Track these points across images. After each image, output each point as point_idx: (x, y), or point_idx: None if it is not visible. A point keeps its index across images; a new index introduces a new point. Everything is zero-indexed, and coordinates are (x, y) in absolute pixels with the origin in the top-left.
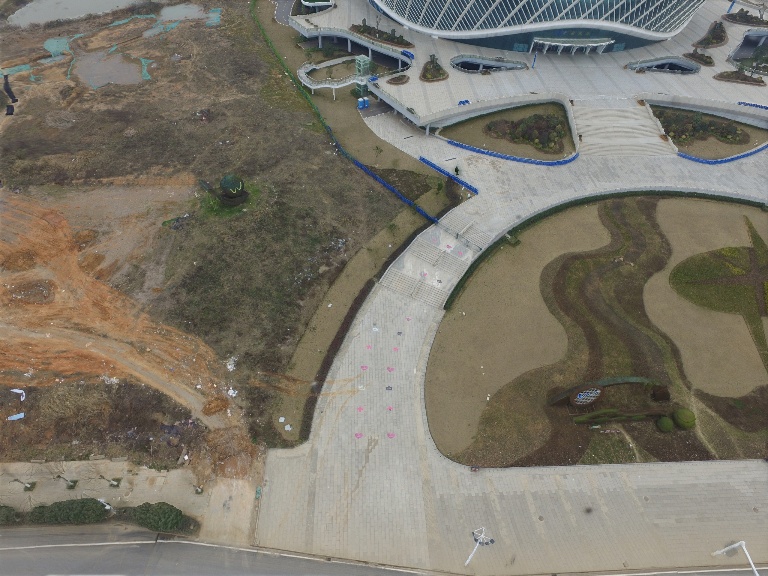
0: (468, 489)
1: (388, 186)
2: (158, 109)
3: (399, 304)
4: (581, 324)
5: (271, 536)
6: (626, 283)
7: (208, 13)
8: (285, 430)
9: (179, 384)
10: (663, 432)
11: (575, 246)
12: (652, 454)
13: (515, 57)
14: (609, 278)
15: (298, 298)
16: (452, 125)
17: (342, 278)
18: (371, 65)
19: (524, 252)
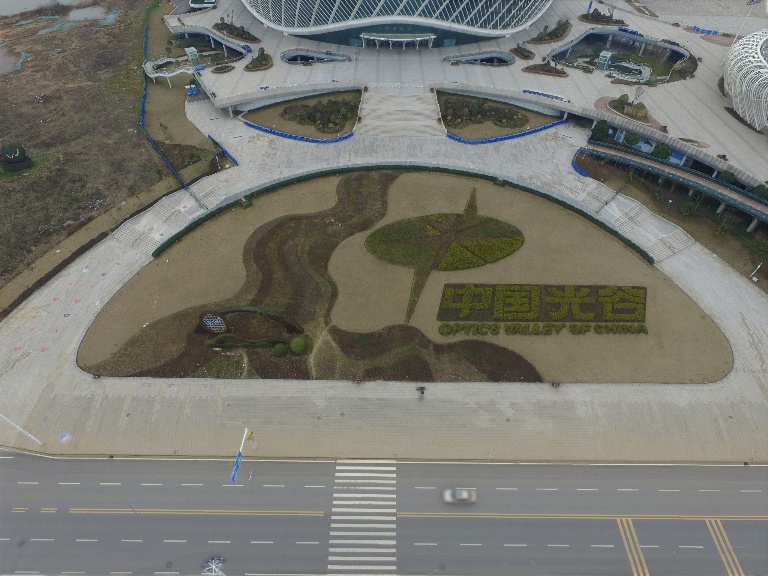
0: (81, 391)
1: (163, 158)
2: (8, 94)
3: (118, 252)
4: (263, 271)
5: None
6: (325, 240)
7: (108, 14)
8: None
9: None
10: (278, 356)
11: (299, 209)
12: (257, 373)
13: (347, 51)
14: (312, 236)
15: (33, 244)
16: (256, 109)
17: (81, 230)
18: (212, 58)
19: (250, 213)
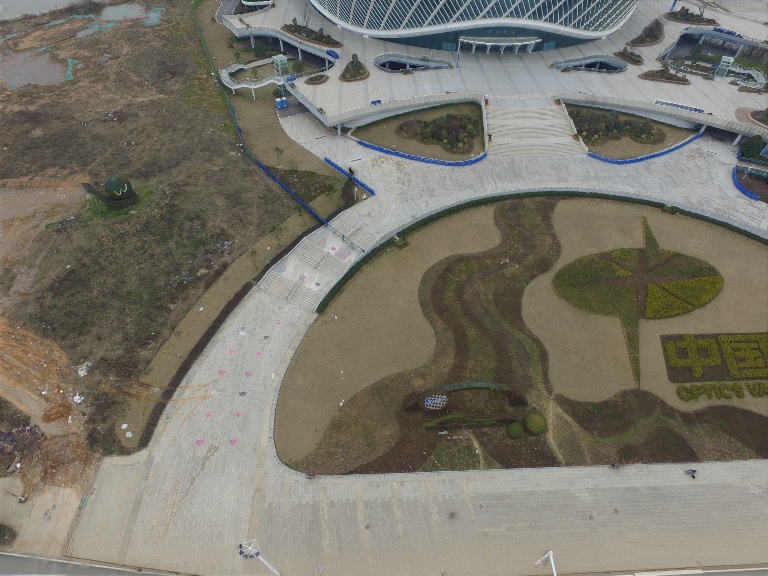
0: (299, 497)
1: (285, 187)
2: (72, 110)
3: (272, 307)
4: (452, 327)
5: (85, 546)
6: (507, 285)
7: (148, 13)
8: (125, 437)
9: (24, 390)
10: (513, 438)
11: (463, 248)
12: (497, 460)
13: (442, 56)
14: (491, 280)
15: (169, 302)
16: (365, 125)
17: (220, 281)
18: (295, 65)
19: (410, 254)
